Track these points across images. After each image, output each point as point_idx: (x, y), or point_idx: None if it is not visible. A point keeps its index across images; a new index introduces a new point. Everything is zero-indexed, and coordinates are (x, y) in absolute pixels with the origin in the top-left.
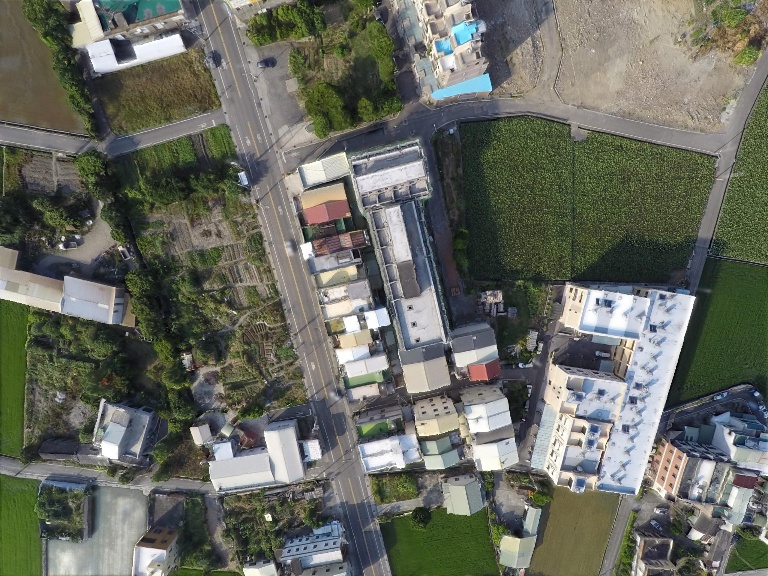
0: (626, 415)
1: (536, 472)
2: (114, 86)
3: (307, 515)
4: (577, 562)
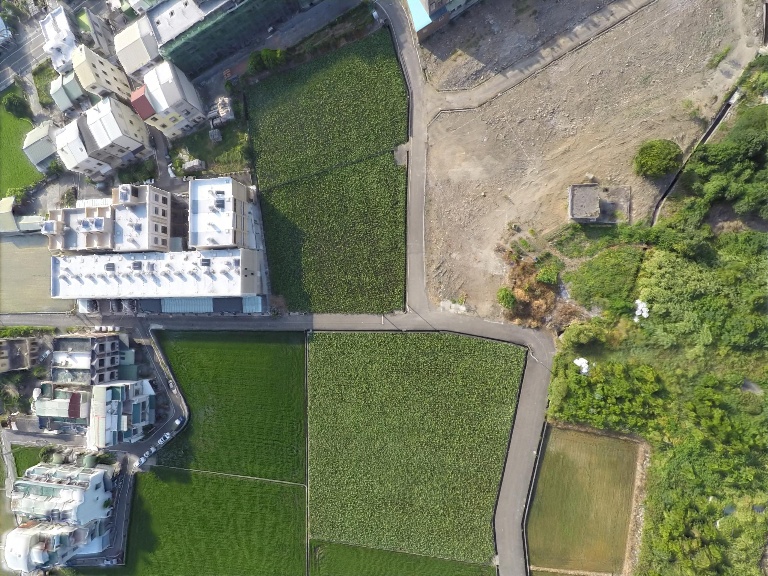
0: (124, 264)
1: None
2: None
3: None
4: (6, 288)
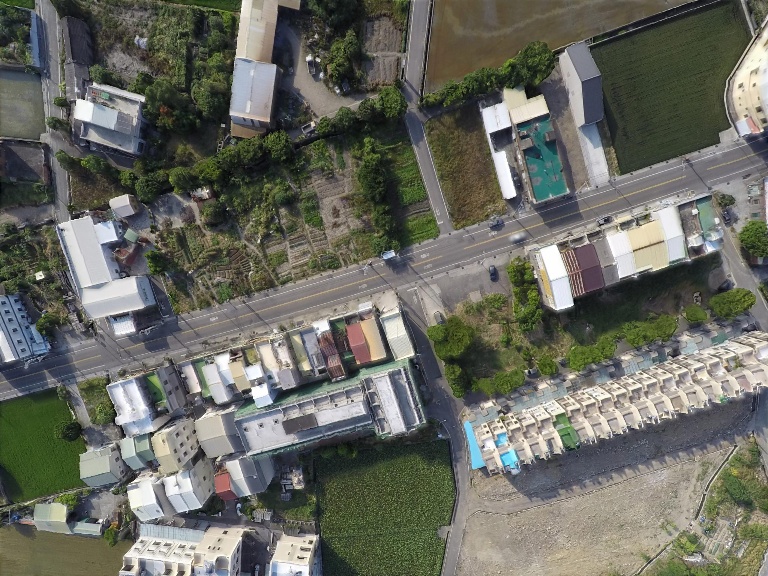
0: None
1: (138, 525)
2: (471, 124)
3: (51, 318)
4: (54, 567)
